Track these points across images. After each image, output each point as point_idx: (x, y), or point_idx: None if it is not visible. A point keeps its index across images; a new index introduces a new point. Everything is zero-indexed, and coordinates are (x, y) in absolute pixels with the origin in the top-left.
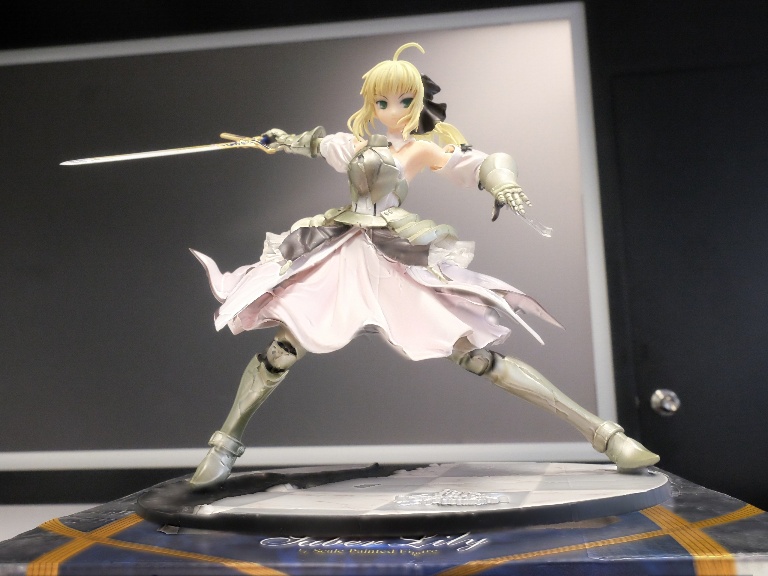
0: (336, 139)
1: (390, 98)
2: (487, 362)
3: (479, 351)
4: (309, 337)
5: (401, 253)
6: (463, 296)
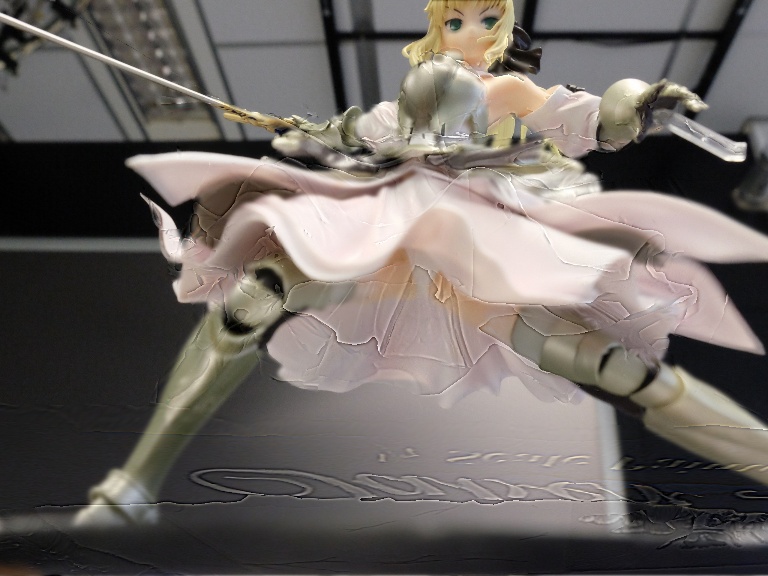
0: (370, 103)
1: (467, 13)
2: (652, 366)
3: (639, 341)
4: (342, 213)
5: (508, 139)
6: (637, 188)
